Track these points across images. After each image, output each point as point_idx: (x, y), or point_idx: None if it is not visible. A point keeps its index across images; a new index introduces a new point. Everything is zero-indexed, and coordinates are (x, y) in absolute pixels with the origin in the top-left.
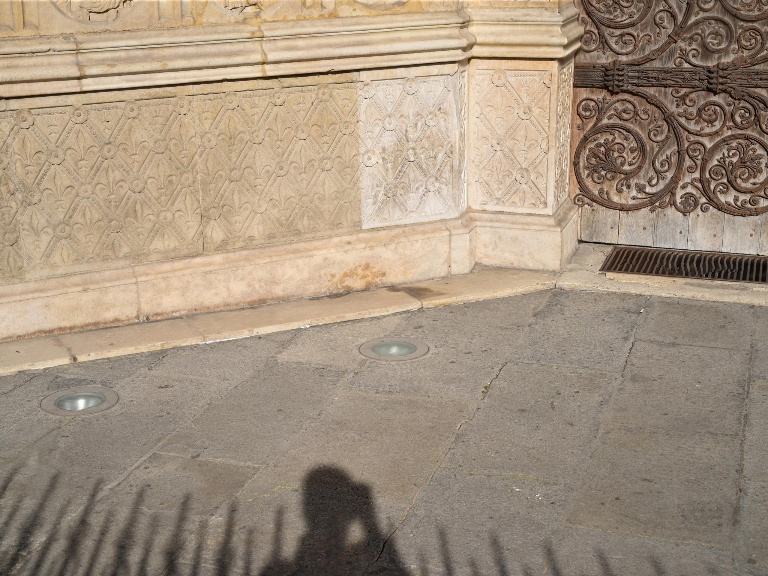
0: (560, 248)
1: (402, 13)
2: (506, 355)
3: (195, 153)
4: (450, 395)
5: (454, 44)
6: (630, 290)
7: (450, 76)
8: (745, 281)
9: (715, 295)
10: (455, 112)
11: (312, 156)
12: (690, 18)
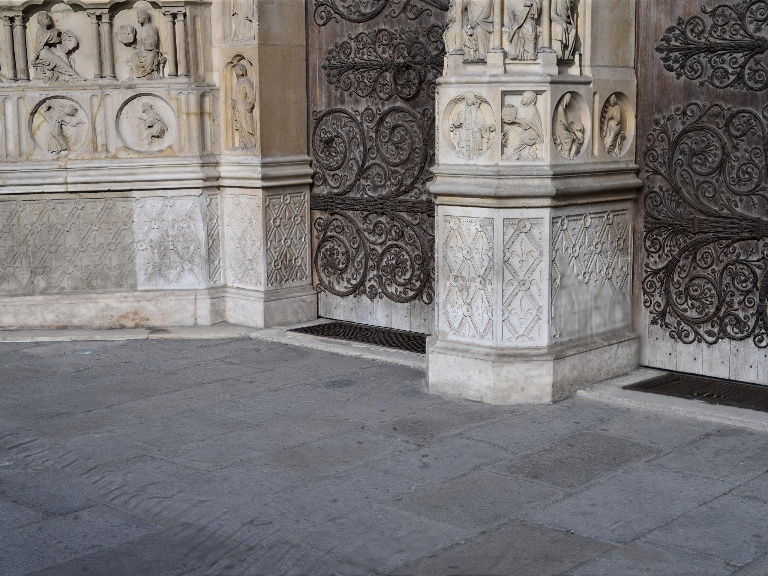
0: (264, 313)
1: (161, 157)
2: (133, 359)
3: (28, 234)
4: (59, 369)
5: (194, 176)
6: (282, 341)
7: (197, 197)
8: (355, 341)
9: (324, 347)
10: (201, 220)
11: (102, 241)
12: (365, 164)
